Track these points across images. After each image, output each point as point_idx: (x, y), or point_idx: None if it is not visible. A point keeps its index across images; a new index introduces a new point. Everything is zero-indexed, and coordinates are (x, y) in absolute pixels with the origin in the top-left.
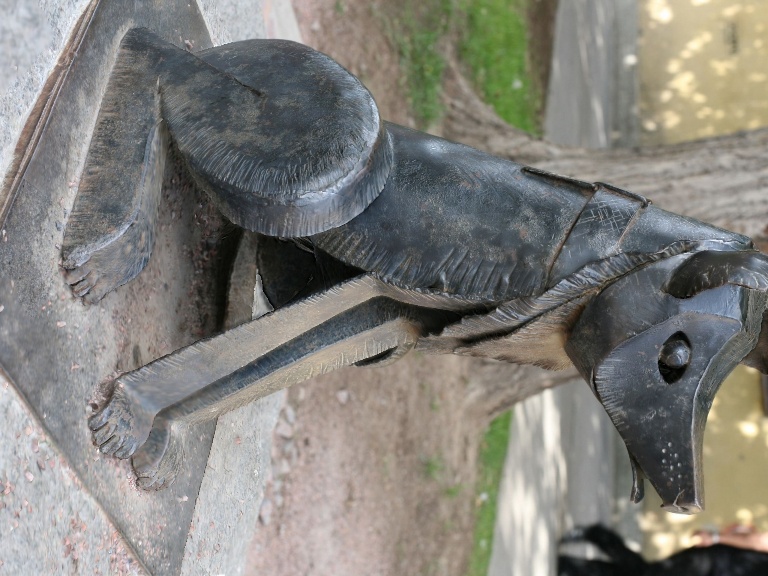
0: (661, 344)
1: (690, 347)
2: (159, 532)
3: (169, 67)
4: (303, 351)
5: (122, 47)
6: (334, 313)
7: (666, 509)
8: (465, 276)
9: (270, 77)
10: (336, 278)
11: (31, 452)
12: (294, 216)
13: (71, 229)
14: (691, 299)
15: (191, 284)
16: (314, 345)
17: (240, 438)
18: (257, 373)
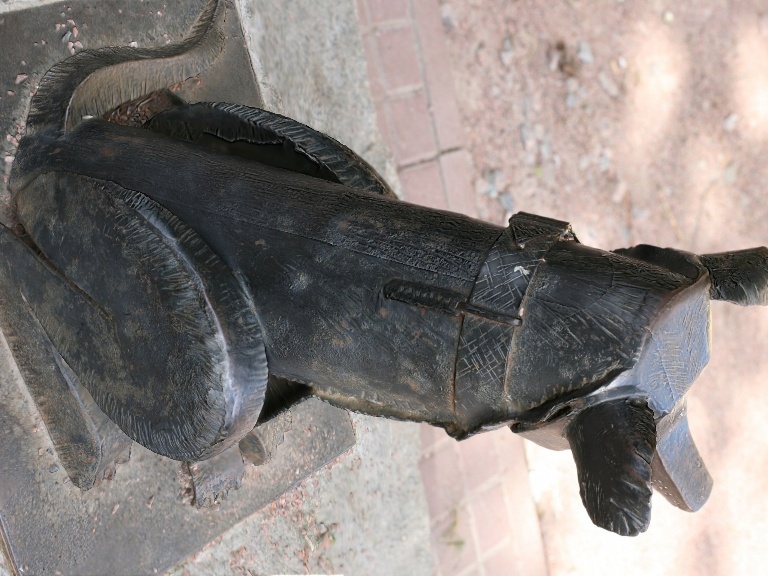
0: None
1: None
2: (309, 435)
3: (21, 276)
4: None
5: None
6: None
7: None
8: None
9: (104, 284)
10: (288, 399)
11: None
12: None
13: (64, 461)
14: None
15: None
16: None
17: None
18: None
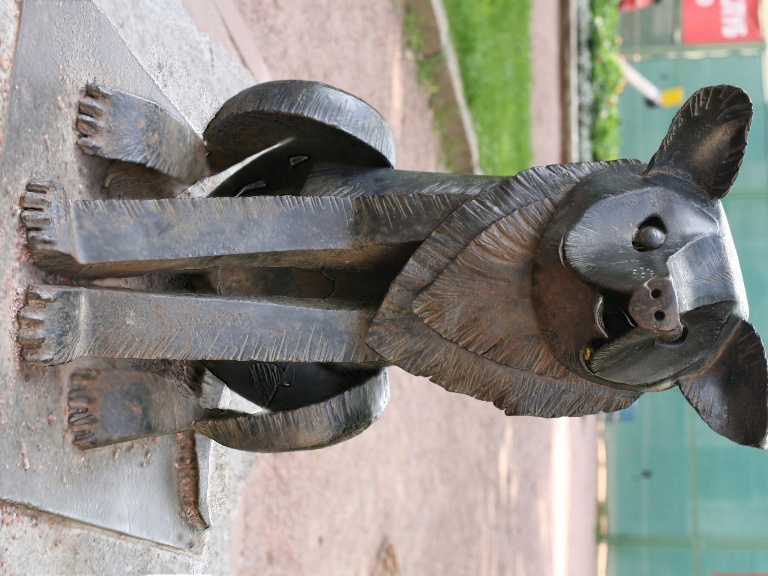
0: (636, 223)
1: (666, 232)
2: None
3: None
4: None
5: None
6: (301, 244)
7: (635, 304)
8: (446, 192)
9: None
10: None
11: None
12: (310, 93)
13: None
14: (668, 186)
15: (133, 360)
16: (262, 301)
17: None
18: None
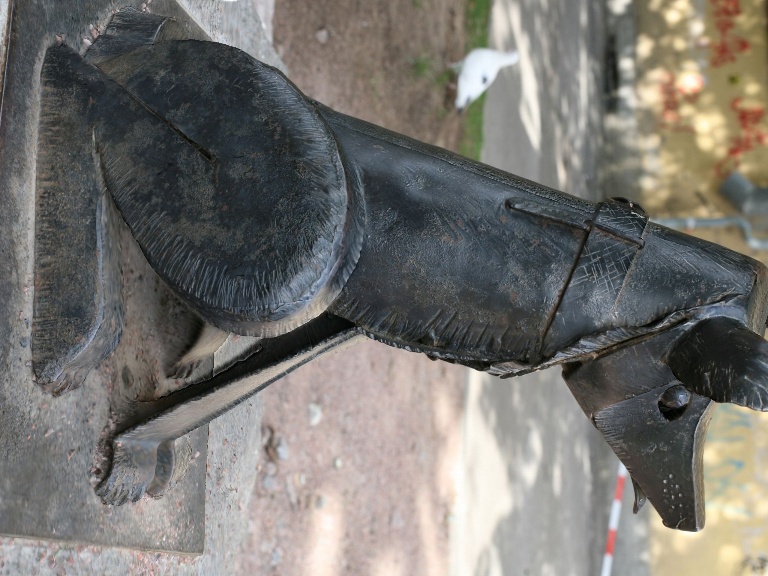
0: (661, 393)
1: (690, 391)
2: (179, 510)
3: (102, 113)
4: None
5: (44, 84)
6: None
7: None
8: (455, 335)
9: (218, 127)
10: (320, 334)
11: (49, 571)
12: (270, 326)
13: (37, 340)
14: None
15: None
16: None
17: None
18: None
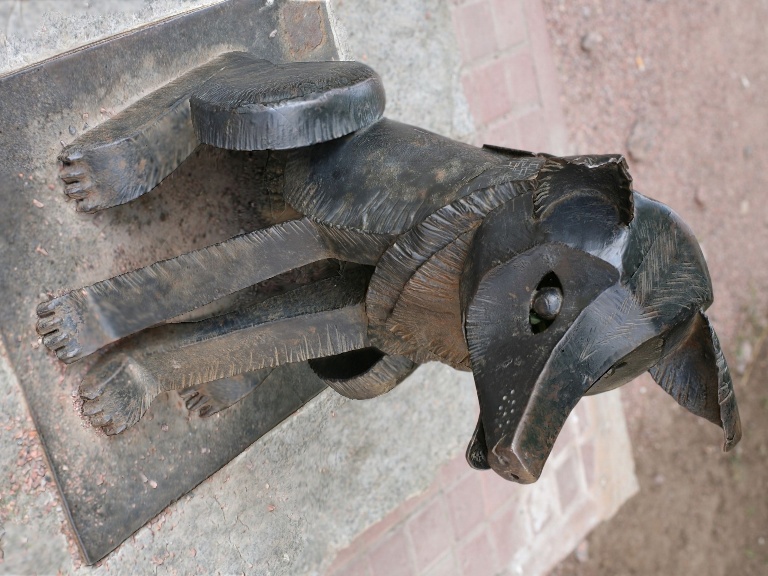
0: (532, 286)
1: (563, 294)
2: (99, 482)
3: (239, 63)
4: (264, 319)
5: (219, 56)
6: (284, 267)
7: (491, 464)
8: (381, 216)
9: (303, 64)
10: (283, 220)
11: None
12: (234, 124)
13: (83, 137)
14: (562, 230)
15: (238, 298)
16: (276, 316)
17: (274, 507)
18: (218, 331)
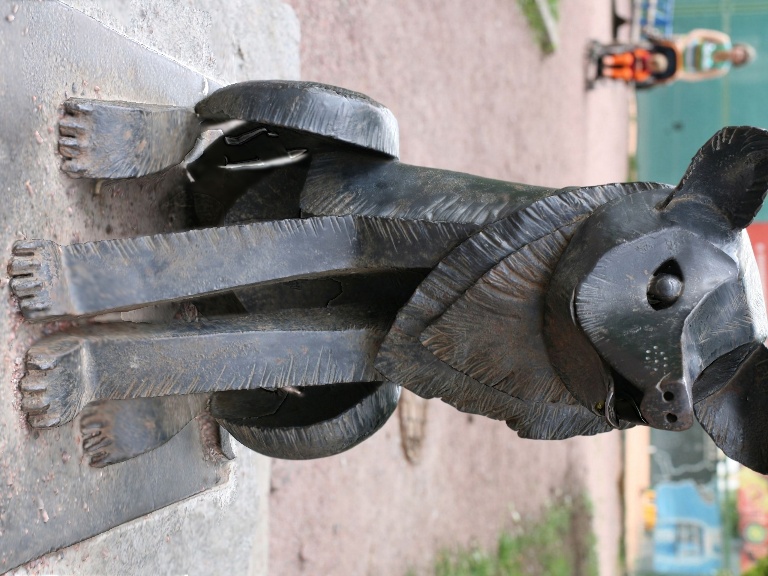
0: (651, 270)
1: (682, 280)
2: (10, 481)
3: None
4: (254, 328)
5: None
6: (303, 268)
7: (647, 405)
8: (453, 214)
9: None
10: None
11: None
12: (303, 101)
13: None
14: (686, 222)
15: None
16: (267, 328)
17: None
18: (197, 332)
